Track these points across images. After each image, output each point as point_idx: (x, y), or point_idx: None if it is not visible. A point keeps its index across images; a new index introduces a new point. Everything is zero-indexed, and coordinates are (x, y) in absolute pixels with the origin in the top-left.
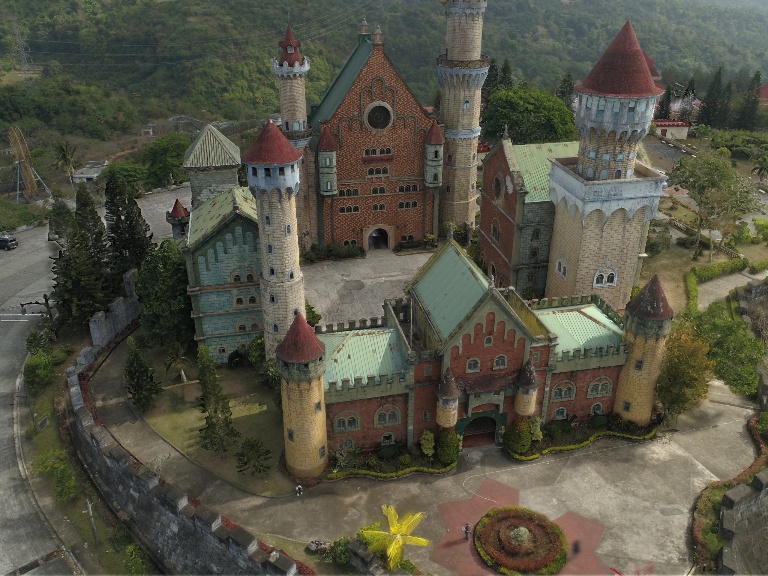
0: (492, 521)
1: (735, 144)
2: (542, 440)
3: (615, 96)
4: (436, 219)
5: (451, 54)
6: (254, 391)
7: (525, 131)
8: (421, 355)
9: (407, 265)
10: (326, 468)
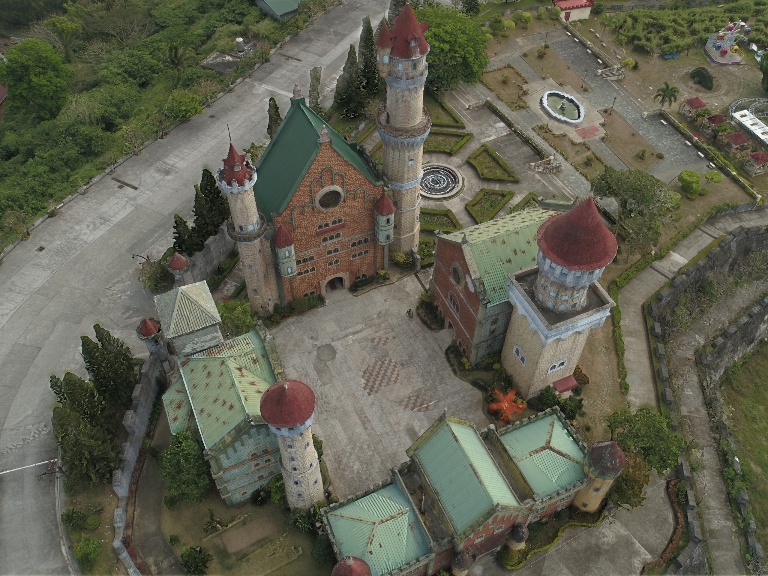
0: None
1: (636, 35)
2: None
3: (579, 270)
4: (386, 257)
5: (394, 121)
6: (284, 530)
7: (442, 75)
8: None
9: (367, 311)
10: None
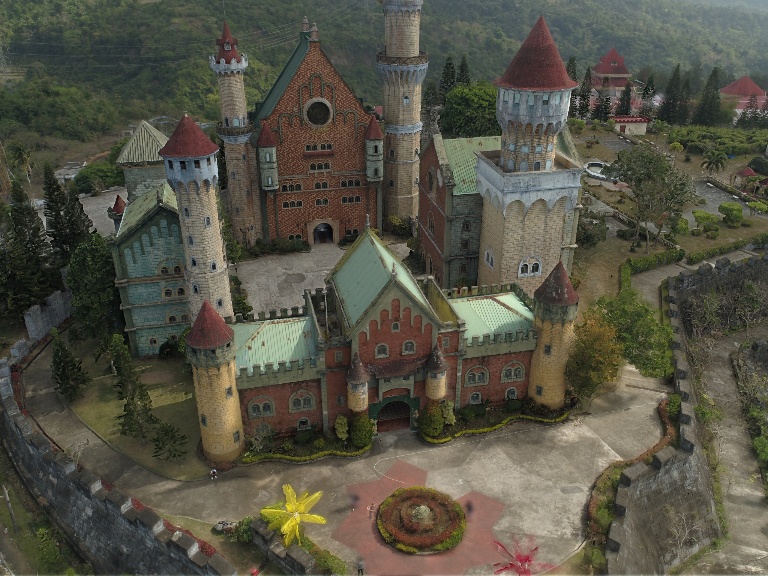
0: (395, 500)
1: (690, 139)
2: (456, 424)
3: (528, 89)
4: (380, 213)
5: (389, 51)
6: (182, 380)
7: (480, 127)
8: (332, 341)
9: None
10: (242, 453)
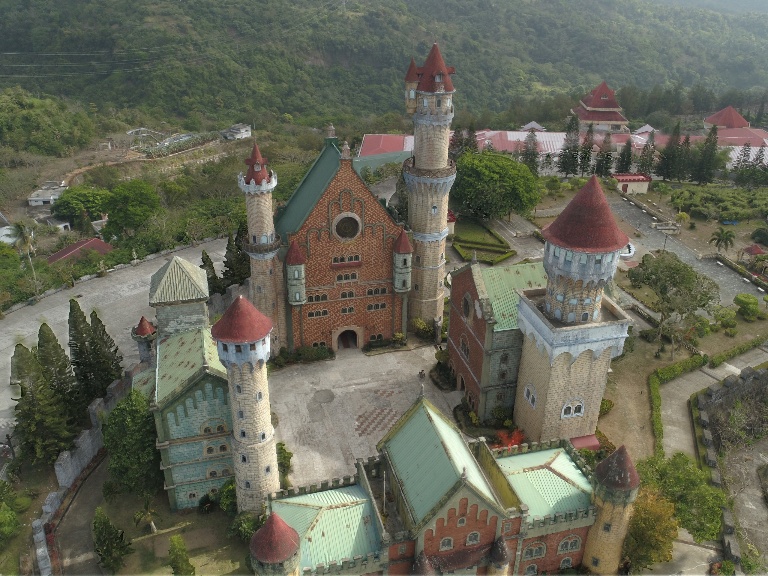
0: None
1: (693, 203)
2: None
3: (582, 251)
4: (405, 318)
5: (419, 162)
6: (226, 543)
7: (491, 201)
8: None
9: (376, 368)
10: None
